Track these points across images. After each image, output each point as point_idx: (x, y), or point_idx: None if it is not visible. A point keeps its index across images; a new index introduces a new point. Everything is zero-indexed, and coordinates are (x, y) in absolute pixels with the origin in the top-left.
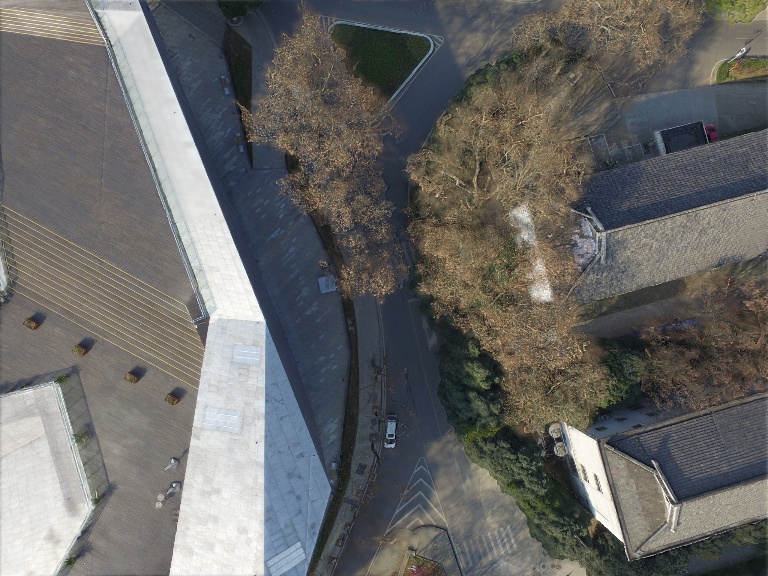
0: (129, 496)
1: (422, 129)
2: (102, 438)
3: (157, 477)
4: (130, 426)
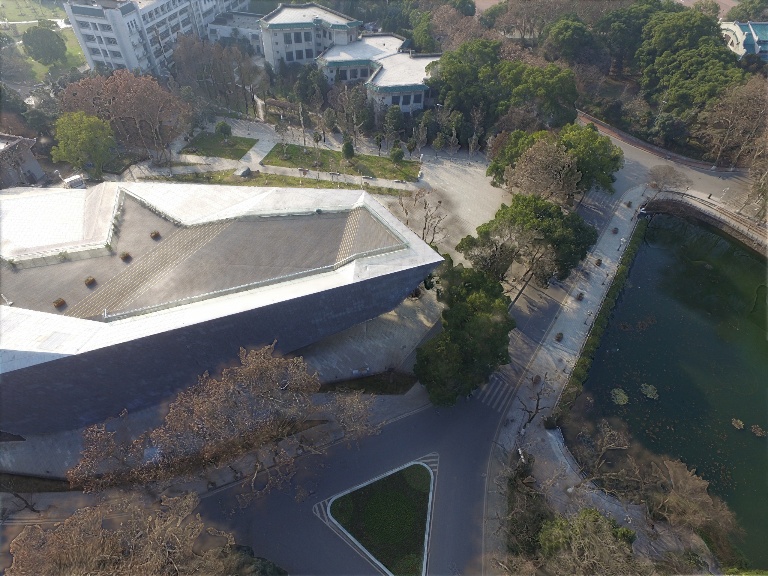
0: (3, 279)
1: (310, 575)
2: (56, 266)
3: (6, 294)
4: (55, 280)
